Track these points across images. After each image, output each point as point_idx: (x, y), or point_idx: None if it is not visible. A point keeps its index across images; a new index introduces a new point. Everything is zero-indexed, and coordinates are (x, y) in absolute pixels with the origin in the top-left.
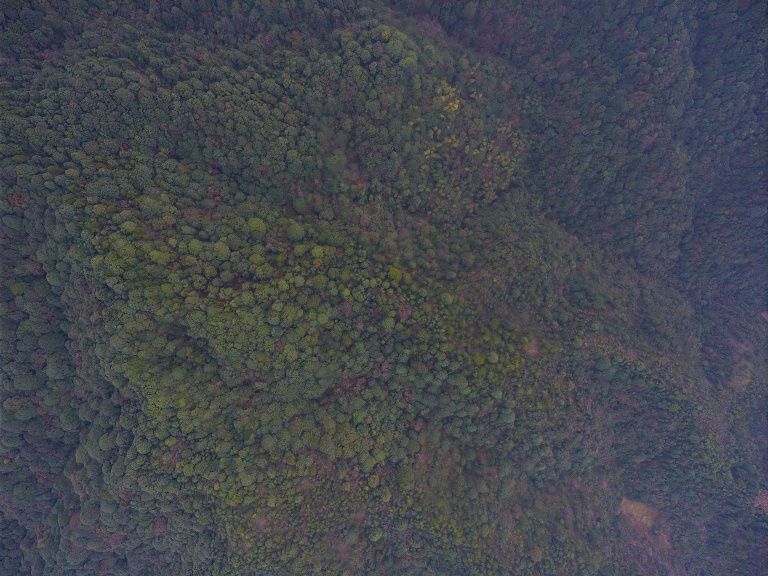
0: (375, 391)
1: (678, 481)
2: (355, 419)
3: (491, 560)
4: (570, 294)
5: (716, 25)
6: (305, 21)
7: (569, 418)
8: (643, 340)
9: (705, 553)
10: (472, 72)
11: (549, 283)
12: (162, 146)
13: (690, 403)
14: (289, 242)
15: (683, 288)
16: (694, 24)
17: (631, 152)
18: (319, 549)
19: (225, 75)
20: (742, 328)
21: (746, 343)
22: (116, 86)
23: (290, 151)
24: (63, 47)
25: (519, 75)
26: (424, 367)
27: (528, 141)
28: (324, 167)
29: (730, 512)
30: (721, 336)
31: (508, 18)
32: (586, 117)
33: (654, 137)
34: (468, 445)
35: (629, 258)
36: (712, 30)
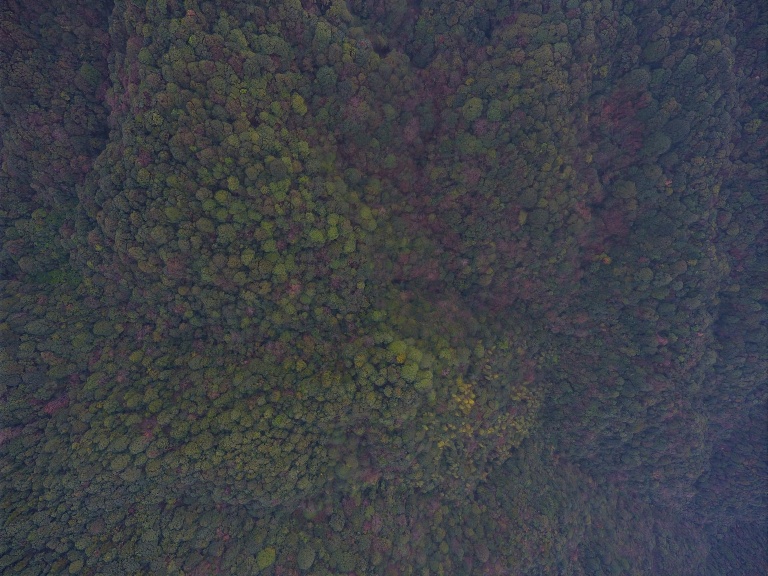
0: None
1: None
2: None
3: None
4: (585, 558)
5: (739, 309)
6: (317, 327)
7: None
8: None
9: None
10: (488, 359)
11: (564, 552)
12: (169, 499)
13: None
14: (299, 569)
15: (699, 522)
16: (716, 302)
17: (649, 421)
18: None
19: (235, 422)
20: (760, 573)
21: None
22: (122, 468)
23: (301, 483)
24: (67, 392)
25: (534, 332)
26: None
27: (543, 390)
28: (335, 475)
29: None
30: None
31: (524, 281)
32: (603, 383)
33: (674, 413)
34: None
35: (644, 496)
36: (735, 311)
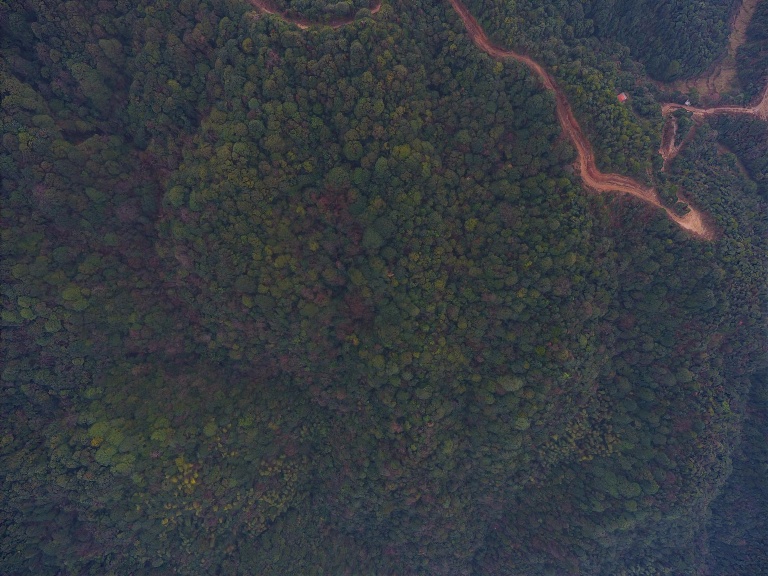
0: None
1: None
2: None
3: None
4: None
5: (478, 399)
6: (30, 401)
7: None
8: None
9: None
10: (219, 438)
11: None
12: None
13: None
14: None
15: None
16: (460, 390)
17: (399, 503)
18: None
19: None
20: None
21: None
22: None
23: None
24: None
25: (296, 406)
26: None
27: (310, 461)
28: (42, 550)
29: None
30: None
31: (281, 355)
32: (355, 462)
33: (416, 498)
34: None
35: (420, 570)
36: (476, 401)
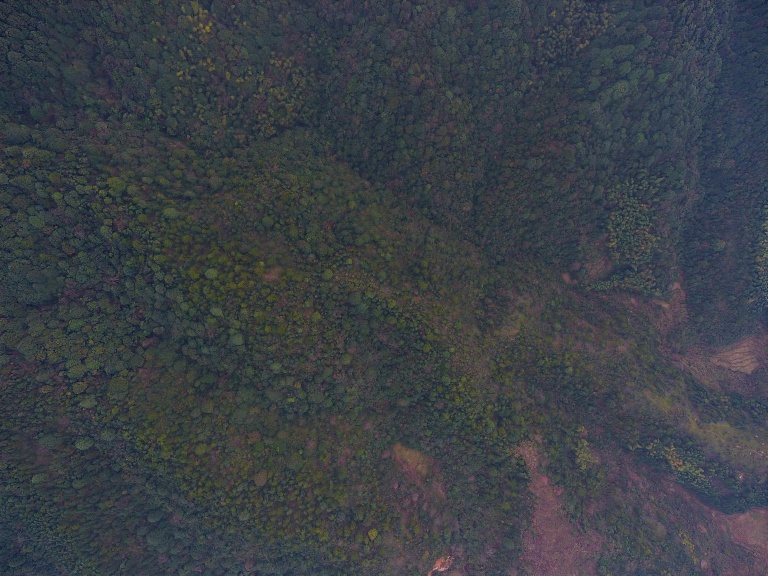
0: (100, 303)
1: (438, 425)
2: (69, 326)
3: (202, 477)
4: (340, 232)
5: None
6: None
7: (310, 348)
8: (405, 281)
9: (477, 504)
10: None
11: (315, 218)
12: None
13: (441, 344)
14: (9, 144)
15: (479, 242)
16: None
17: (403, 93)
18: (6, 447)
19: None
20: (526, 282)
21: (525, 296)
22: None
23: (10, 52)
24: None
25: (304, 12)
26: (140, 279)
27: (318, 81)
28: (63, 77)
29: (495, 462)
30: (502, 288)
31: None
32: None
33: (420, 78)
34: (210, 369)
35: (423, 207)
36: None
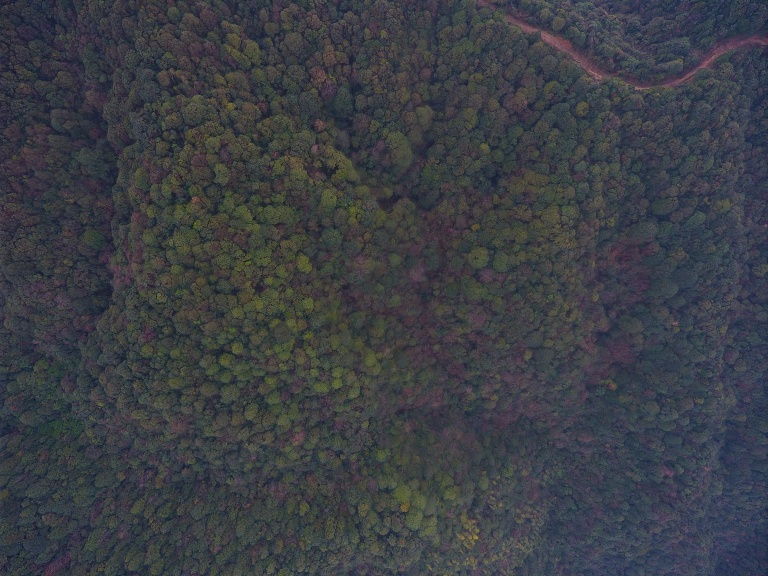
0: None
1: None
2: None
3: None
4: None
5: (746, 439)
6: (320, 467)
7: None
8: None
9: None
10: (492, 491)
11: None
12: None
13: None
14: None
15: None
16: (722, 430)
17: (655, 544)
18: None
19: None
20: None
21: None
22: None
23: None
24: (68, 550)
25: (539, 450)
26: None
27: (547, 503)
28: None
29: None
30: None
31: (529, 402)
32: (608, 505)
33: (679, 540)
34: None
35: None
36: (741, 440)
